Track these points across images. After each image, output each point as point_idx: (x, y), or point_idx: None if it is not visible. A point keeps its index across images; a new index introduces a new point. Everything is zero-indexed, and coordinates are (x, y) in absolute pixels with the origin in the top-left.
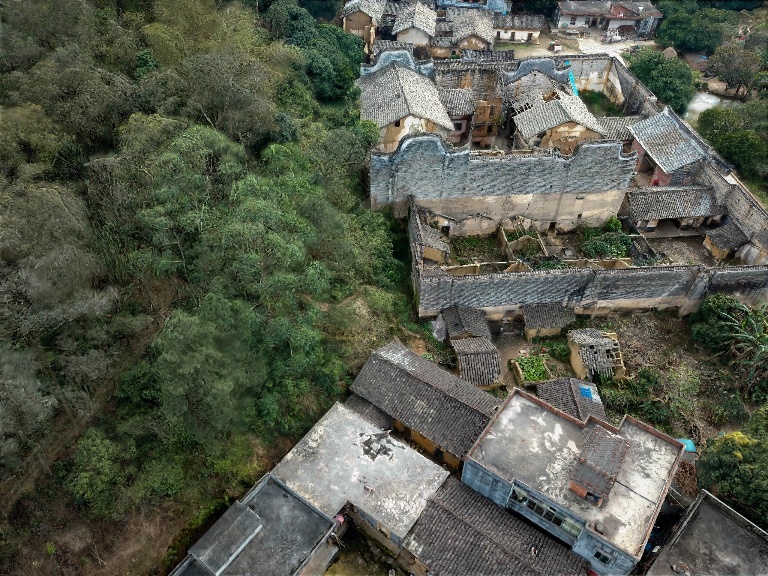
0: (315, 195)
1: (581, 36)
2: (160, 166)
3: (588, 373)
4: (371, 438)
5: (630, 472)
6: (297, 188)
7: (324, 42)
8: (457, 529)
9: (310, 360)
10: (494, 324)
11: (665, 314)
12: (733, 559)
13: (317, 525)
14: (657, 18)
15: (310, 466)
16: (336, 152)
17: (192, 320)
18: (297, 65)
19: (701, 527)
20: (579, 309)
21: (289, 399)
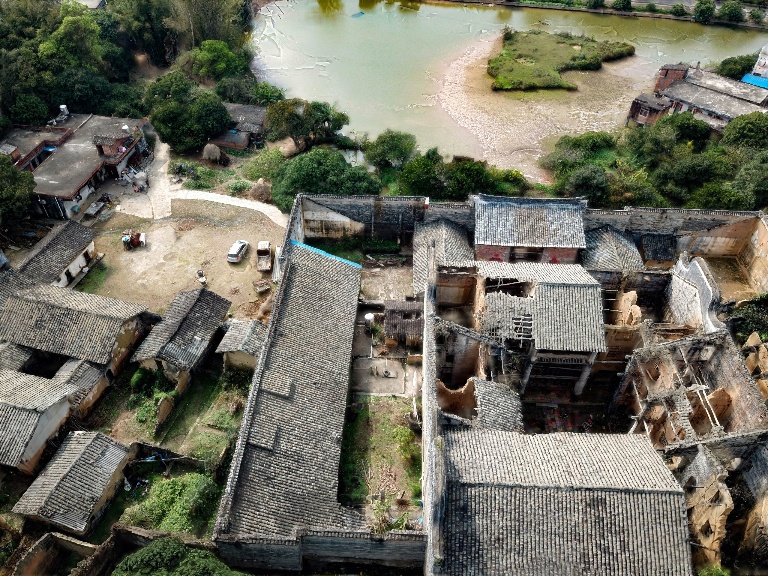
0: None
1: (109, 205)
2: None
3: None
4: None
5: None
6: None
7: None
8: None
9: None
10: None
11: None
12: None
13: None
14: None
15: None
16: None
17: None
18: None
19: None
20: None
21: None
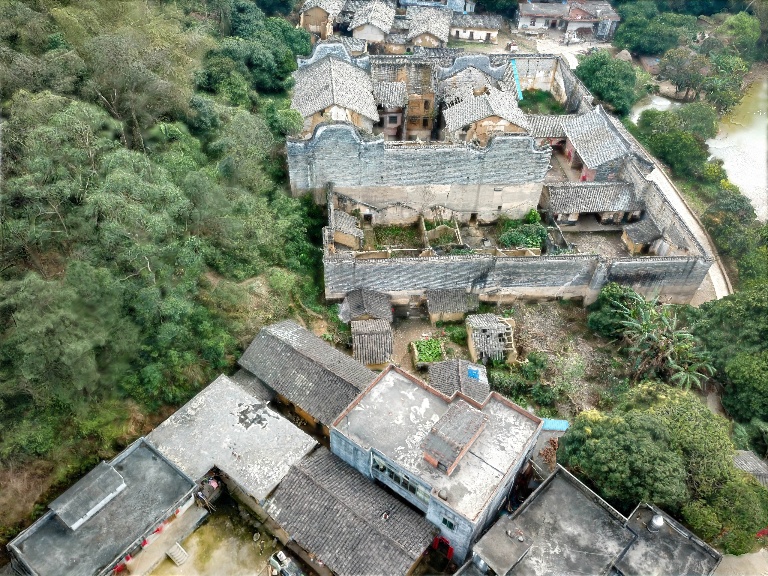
0: (197, 172)
1: (540, 37)
2: (35, 138)
3: (479, 356)
4: (249, 408)
5: (486, 445)
6: (181, 165)
7: (269, 35)
8: (314, 494)
9: (198, 333)
10: (402, 308)
11: (569, 303)
12: (575, 529)
13: (179, 486)
14: (615, 21)
15: (184, 432)
16: (241, 136)
17: (47, 282)
18: (236, 56)
19: (551, 499)
20: (484, 296)
21: (174, 369)
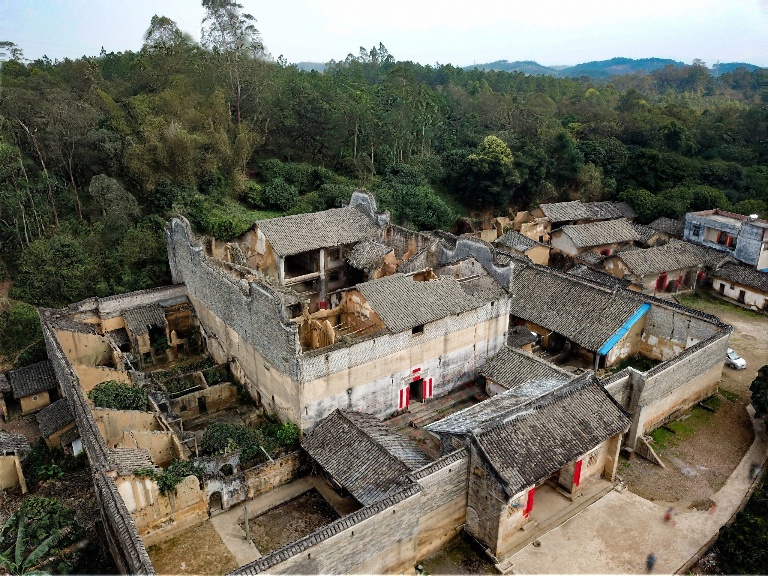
0: None
1: None
2: None
3: None
4: None
5: None
6: None
7: None
8: None
9: None
10: None
11: (103, 526)
12: None
13: None
14: None
15: None
16: None
17: None
18: (322, 193)
19: None
20: None
21: None
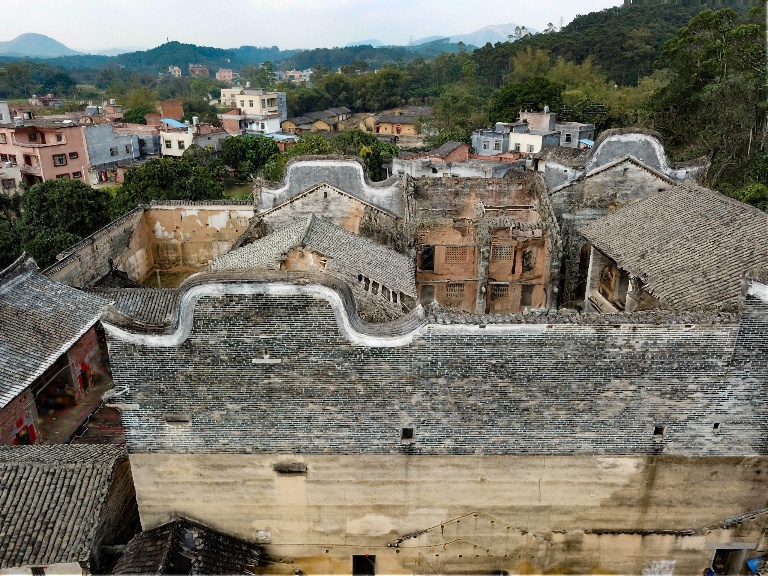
0: (688, 50)
1: None
2: None
3: None
4: None
5: None
6: None
7: None
8: None
9: None
10: None
11: None
12: None
13: None
14: None
15: None
16: None
17: None
18: None
19: None
20: None
21: None
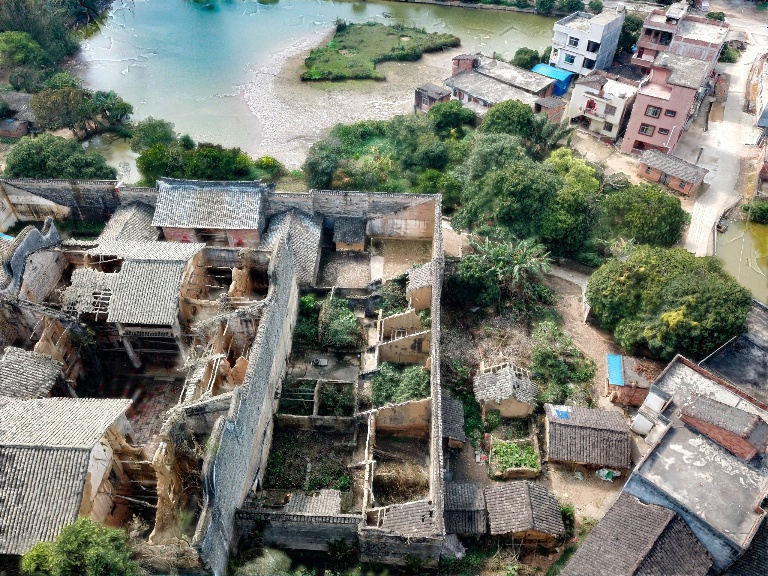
0: None
1: None
2: None
3: (535, 404)
4: None
5: None
6: None
7: None
8: None
9: None
10: None
11: (440, 315)
12: (750, 371)
13: None
14: None
15: None
16: None
17: None
18: None
19: None
20: None
21: None
